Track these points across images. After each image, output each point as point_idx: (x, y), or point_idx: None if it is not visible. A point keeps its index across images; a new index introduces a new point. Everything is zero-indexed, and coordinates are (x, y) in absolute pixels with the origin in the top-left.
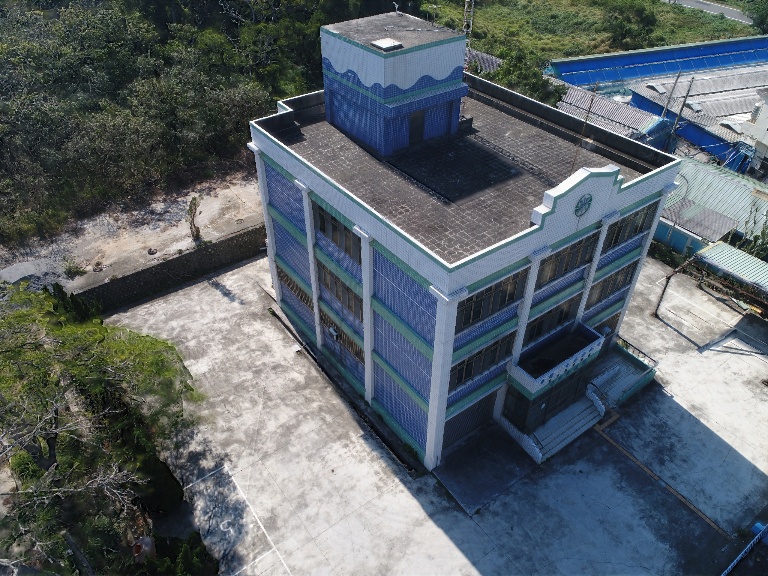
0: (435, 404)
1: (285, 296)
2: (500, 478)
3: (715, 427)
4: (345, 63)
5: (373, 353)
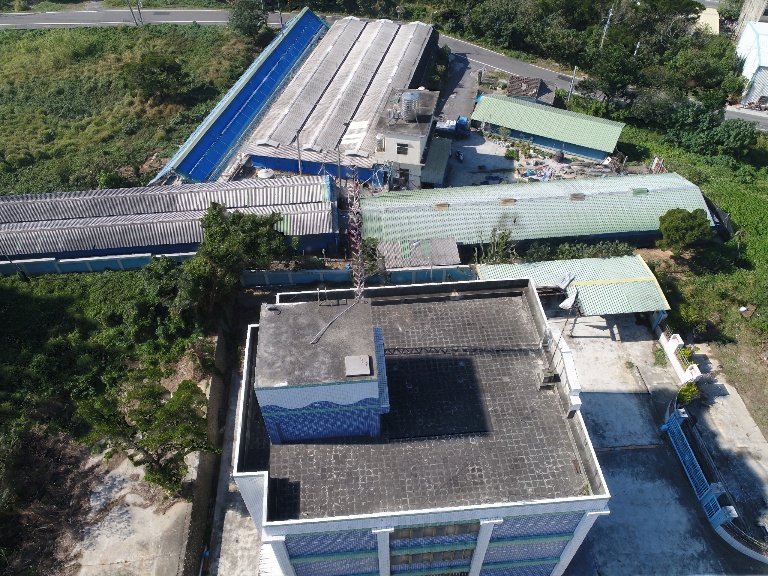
0: (571, 556)
1: None
2: None
3: (590, 389)
4: (308, 400)
5: (483, 567)
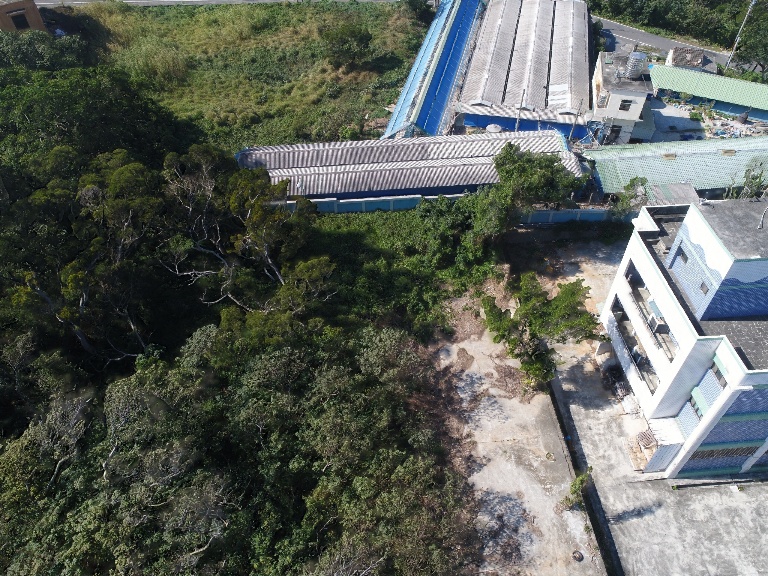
0: None
1: (684, 467)
2: None
3: None
4: (765, 274)
5: None
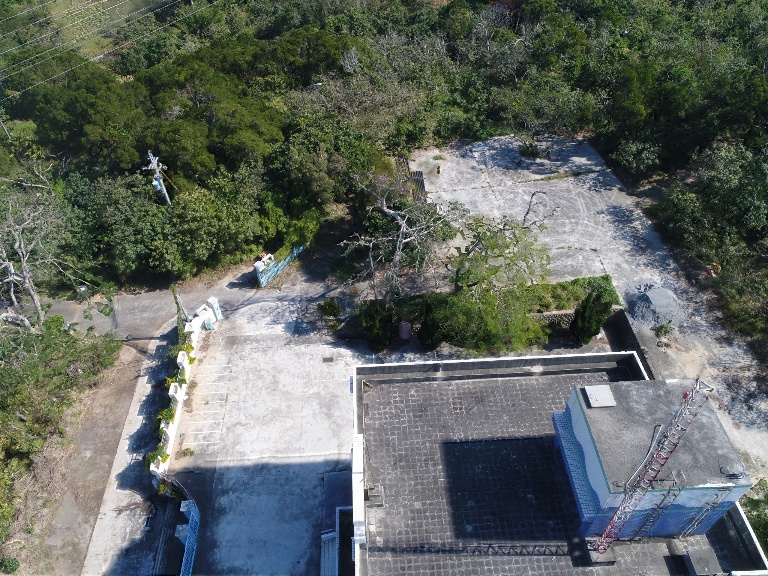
0: None
1: None
2: (331, 506)
3: None
4: None
5: None
